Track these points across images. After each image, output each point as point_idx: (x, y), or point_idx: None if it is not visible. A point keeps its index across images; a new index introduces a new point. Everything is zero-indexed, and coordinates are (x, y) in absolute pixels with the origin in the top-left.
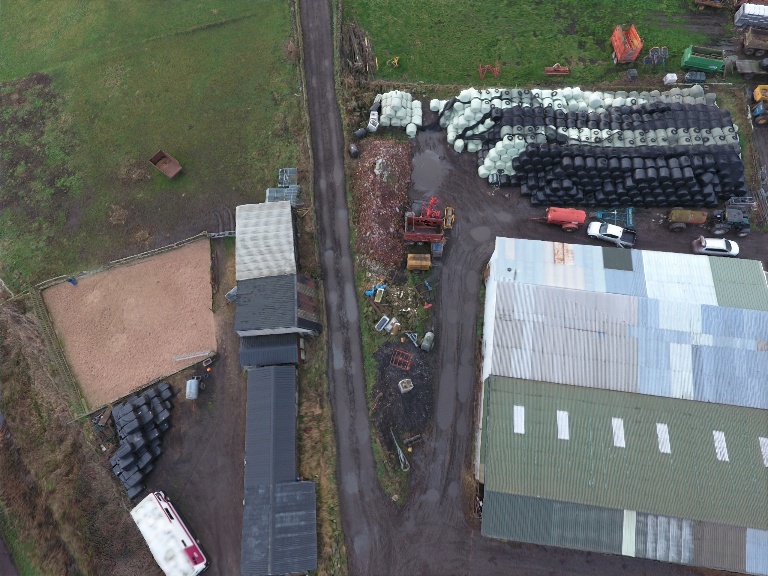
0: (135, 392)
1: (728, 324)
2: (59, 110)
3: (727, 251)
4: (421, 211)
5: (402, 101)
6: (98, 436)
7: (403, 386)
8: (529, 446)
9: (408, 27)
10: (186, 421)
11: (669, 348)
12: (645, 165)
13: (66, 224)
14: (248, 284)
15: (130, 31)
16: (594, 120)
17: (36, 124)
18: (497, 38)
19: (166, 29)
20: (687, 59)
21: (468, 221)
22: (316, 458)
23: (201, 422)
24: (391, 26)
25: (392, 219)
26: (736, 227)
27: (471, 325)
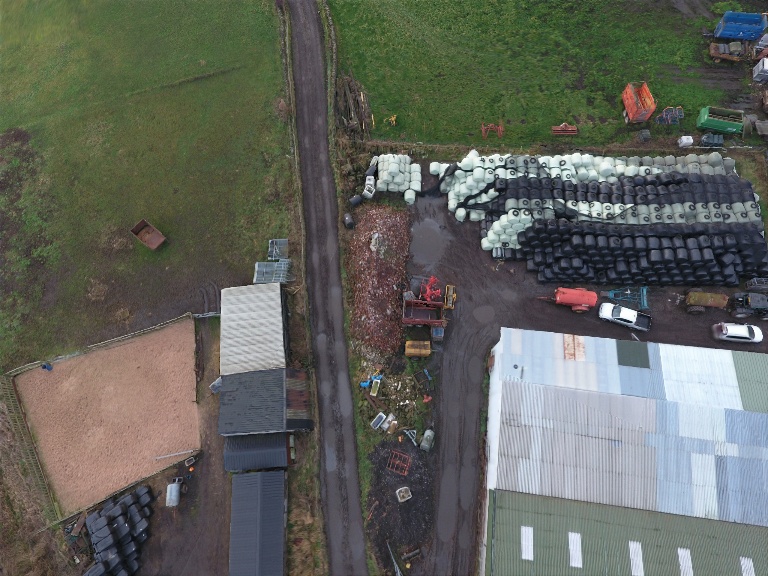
0: (111, 497)
1: (755, 432)
2: (37, 171)
3: (750, 339)
4: (420, 289)
5: (400, 166)
6: (71, 547)
7: (401, 496)
8: (538, 575)
9: (406, 80)
10: (166, 529)
11: (690, 459)
12: (661, 245)
13: (42, 300)
14: (233, 380)
15: (113, 83)
16: (605, 193)
17: (13, 186)
18: (501, 93)
19: (151, 82)
20: (704, 121)
21: (470, 300)
22: (306, 575)
23: (182, 530)
24: (388, 79)
25: (389, 299)
26: (759, 312)
27: (474, 420)
